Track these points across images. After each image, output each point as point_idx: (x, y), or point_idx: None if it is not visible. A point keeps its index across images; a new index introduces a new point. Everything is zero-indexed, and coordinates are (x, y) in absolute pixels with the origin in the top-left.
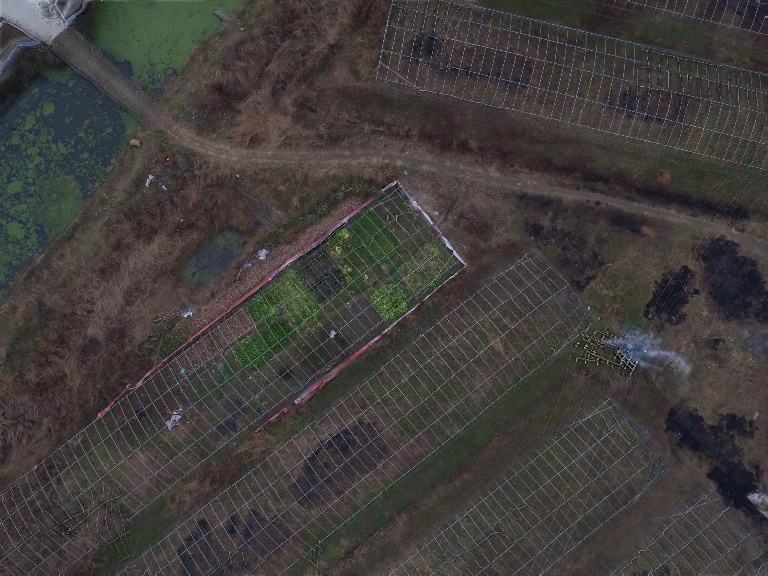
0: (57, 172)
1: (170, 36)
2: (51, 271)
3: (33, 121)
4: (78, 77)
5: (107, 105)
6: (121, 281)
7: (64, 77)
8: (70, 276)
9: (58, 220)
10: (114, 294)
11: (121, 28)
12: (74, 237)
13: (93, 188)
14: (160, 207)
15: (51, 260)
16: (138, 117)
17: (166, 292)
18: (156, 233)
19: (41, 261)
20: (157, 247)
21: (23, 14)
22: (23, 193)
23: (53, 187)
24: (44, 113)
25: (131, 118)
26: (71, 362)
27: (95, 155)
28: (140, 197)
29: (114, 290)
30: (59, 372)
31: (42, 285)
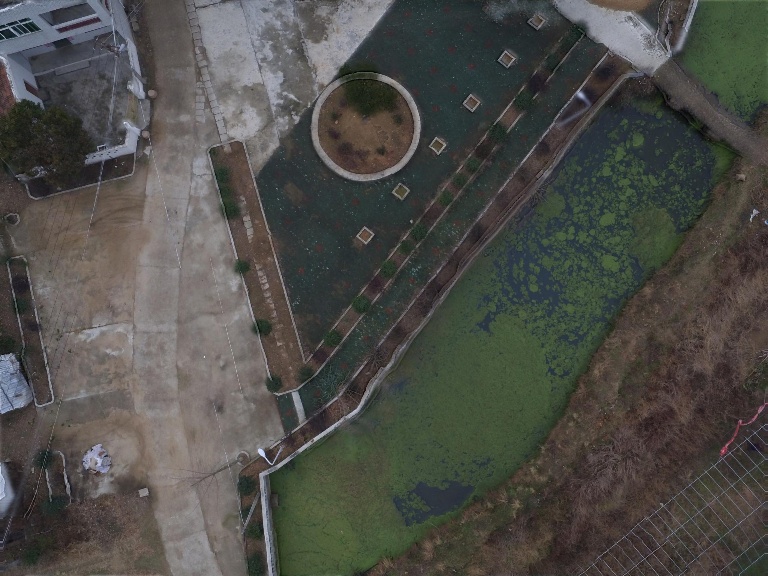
0: (649, 205)
1: (755, 68)
2: (663, 306)
3: (623, 153)
4: (666, 109)
5: (696, 138)
6: (724, 316)
7: (653, 108)
8: (681, 311)
9: (652, 253)
10: (717, 329)
11: (706, 59)
12: (683, 272)
13: (686, 221)
14: (763, 243)
15: (662, 295)
16: (737, 151)
17: (767, 328)
18: (757, 268)
19: (652, 296)
20: (761, 283)
21: (626, 45)
22: (616, 225)
23: (646, 220)
24: (634, 145)
25: (725, 151)
26: (678, 397)
27: (686, 188)
28: (745, 232)
29: (718, 325)
30: (664, 407)
31: (654, 320)
